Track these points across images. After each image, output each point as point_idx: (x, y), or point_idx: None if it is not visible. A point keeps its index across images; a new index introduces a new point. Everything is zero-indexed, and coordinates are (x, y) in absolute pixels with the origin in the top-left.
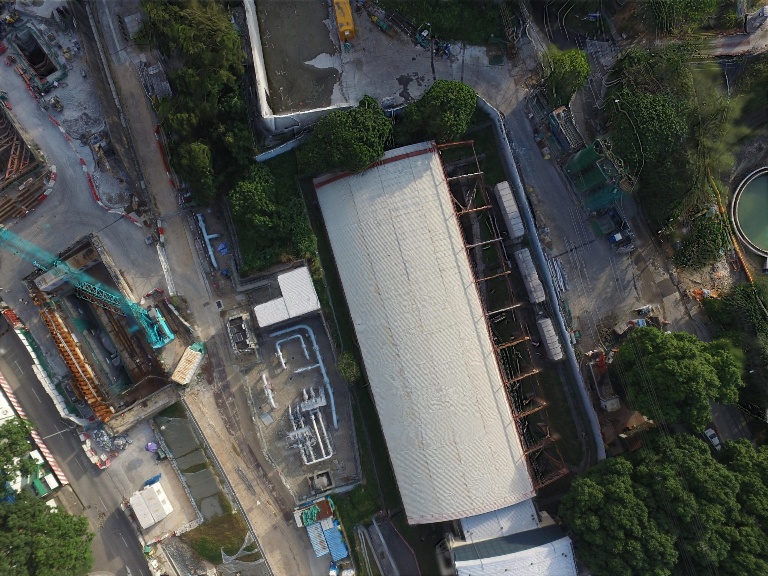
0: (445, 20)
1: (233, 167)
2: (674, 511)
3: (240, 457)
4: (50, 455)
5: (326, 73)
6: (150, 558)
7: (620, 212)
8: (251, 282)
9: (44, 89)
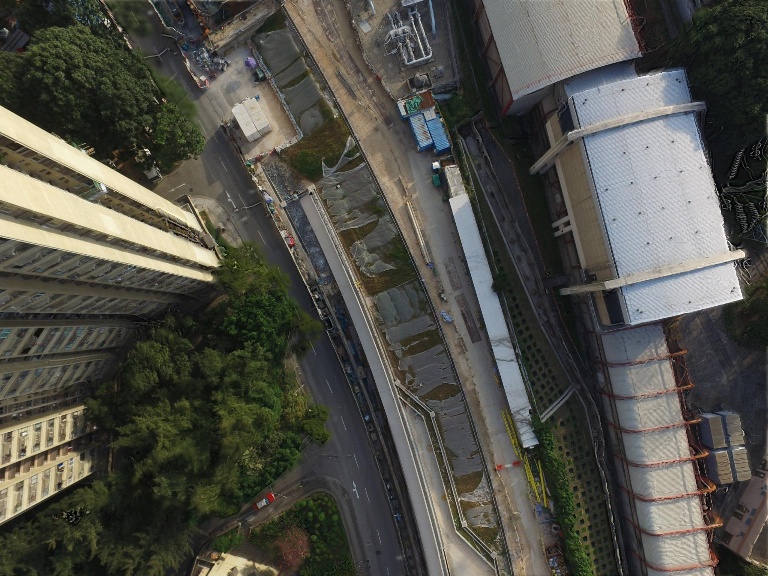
0: None
1: None
2: None
3: (340, 63)
4: (150, 77)
5: None
6: (252, 172)
7: None
8: None
9: None
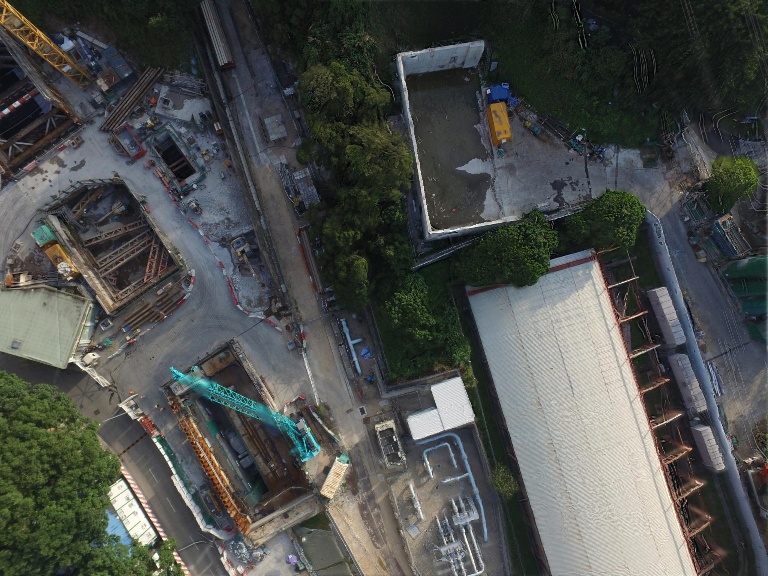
0: (604, 127)
1: (382, 274)
2: None
3: (386, 571)
4: (185, 567)
5: (478, 179)
6: None
7: None
8: (398, 390)
9: (183, 192)
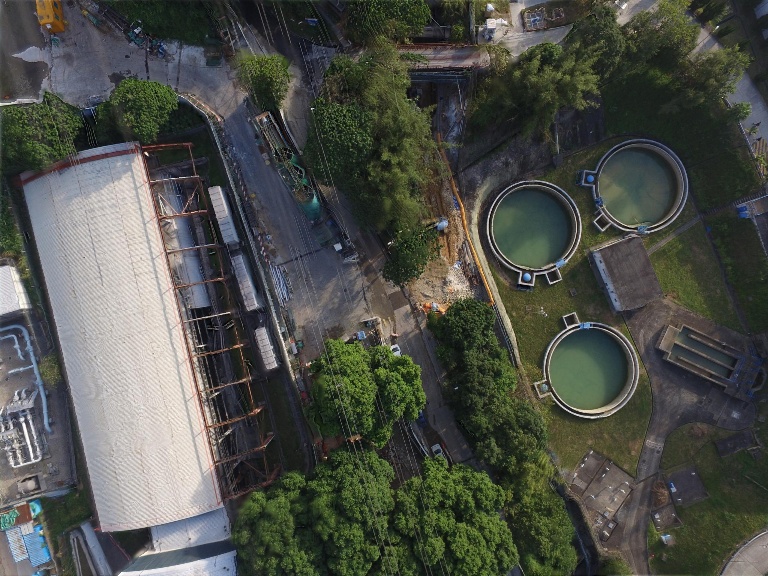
0: (150, 18)
1: None
2: (316, 528)
3: None
4: None
5: (35, 67)
6: None
7: (338, 222)
8: None
9: None
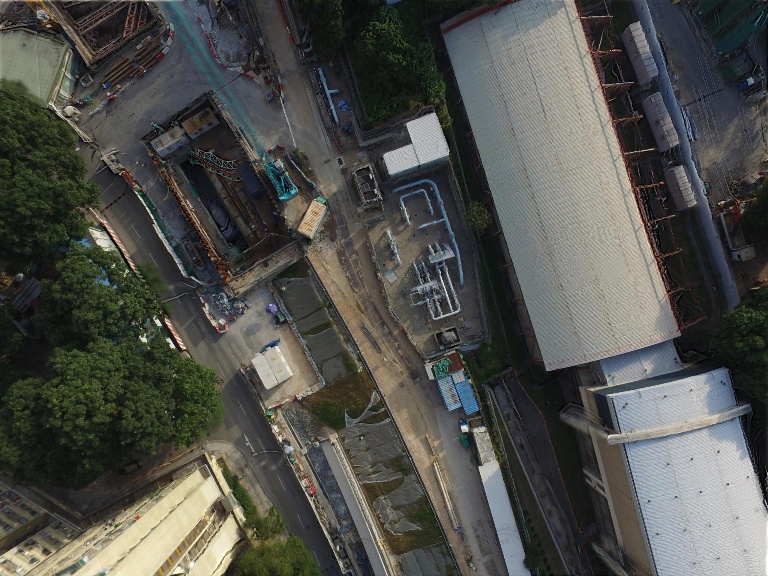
0: None
1: (358, 15)
2: None
3: (364, 315)
4: (168, 320)
5: None
6: (272, 422)
7: (753, 55)
8: (375, 135)
9: None
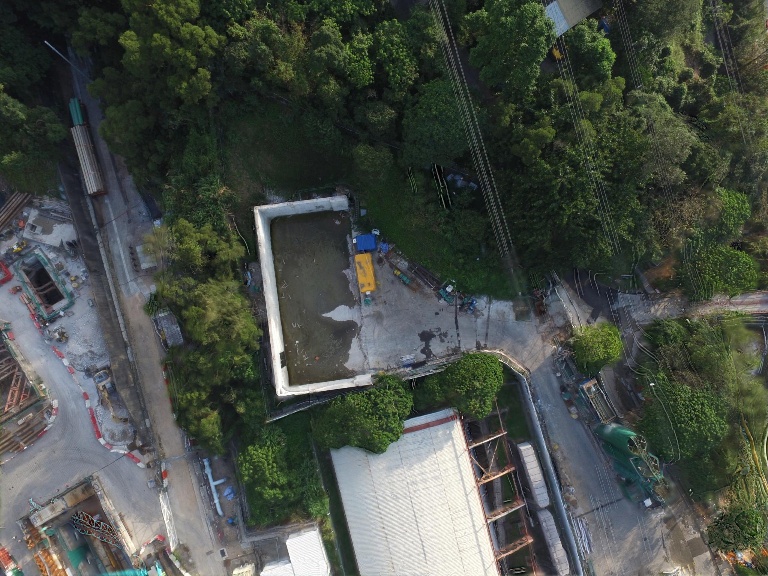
0: (471, 283)
1: None
2: None
3: None
4: None
5: (344, 326)
6: None
7: None
8: (258, 536)
9: (49, 319)
